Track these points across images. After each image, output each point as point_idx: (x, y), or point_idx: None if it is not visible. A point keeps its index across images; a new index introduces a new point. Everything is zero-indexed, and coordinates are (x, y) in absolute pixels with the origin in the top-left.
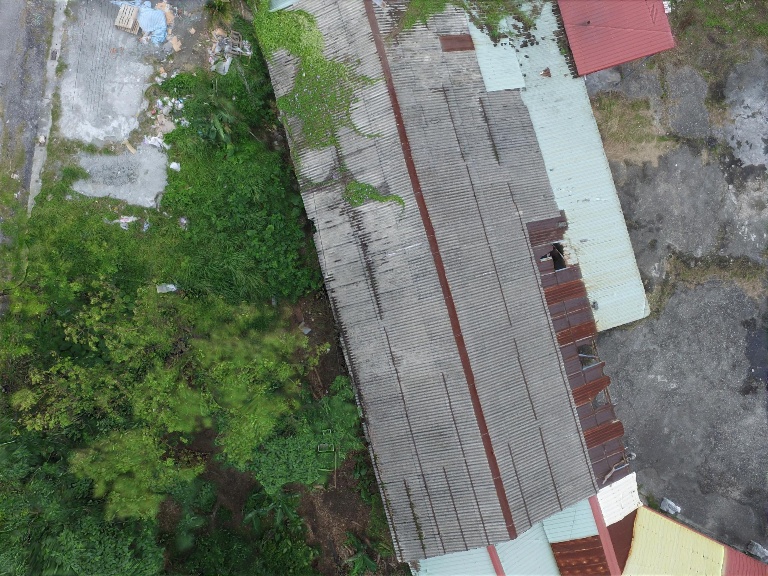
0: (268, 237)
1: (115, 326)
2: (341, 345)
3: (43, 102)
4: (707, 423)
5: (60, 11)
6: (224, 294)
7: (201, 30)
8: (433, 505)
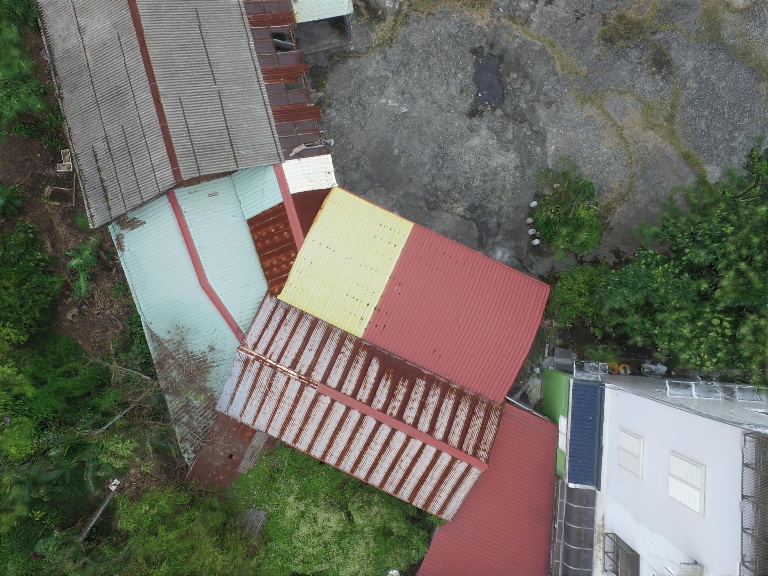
0: None
1: None
2: (39, 26)
3: None
4: (435, 144)
5: None
6: None
7: None
8: (115, 165)
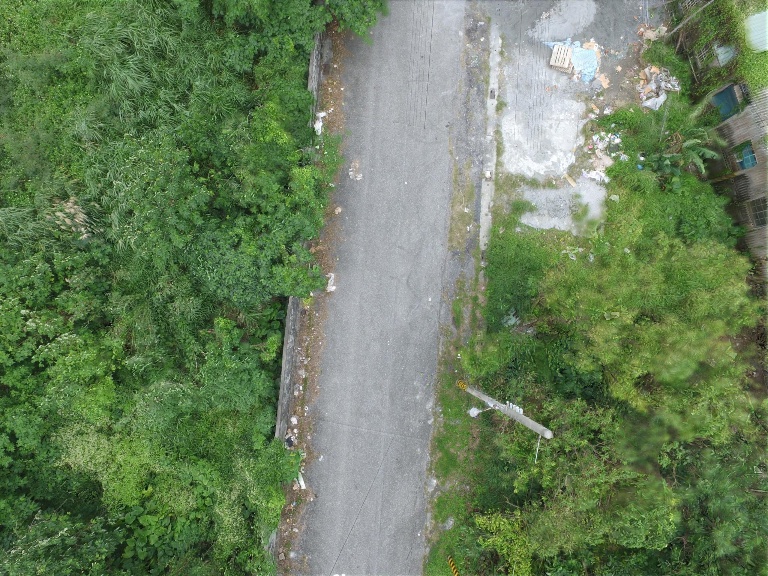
0: (721, 266)
1: (577, 353)
2: None
3: (486, 139)
4: None
5: (495, 52)
6: (679, 321)
7: (627, 67)
8: None
